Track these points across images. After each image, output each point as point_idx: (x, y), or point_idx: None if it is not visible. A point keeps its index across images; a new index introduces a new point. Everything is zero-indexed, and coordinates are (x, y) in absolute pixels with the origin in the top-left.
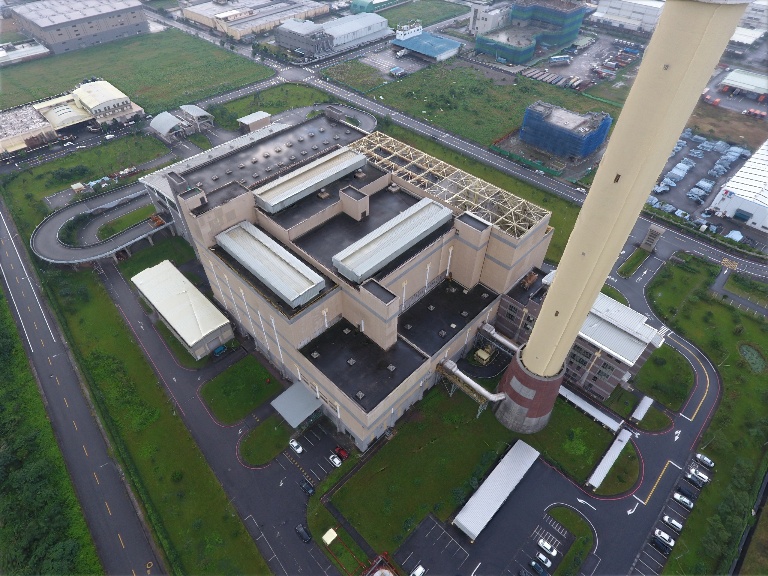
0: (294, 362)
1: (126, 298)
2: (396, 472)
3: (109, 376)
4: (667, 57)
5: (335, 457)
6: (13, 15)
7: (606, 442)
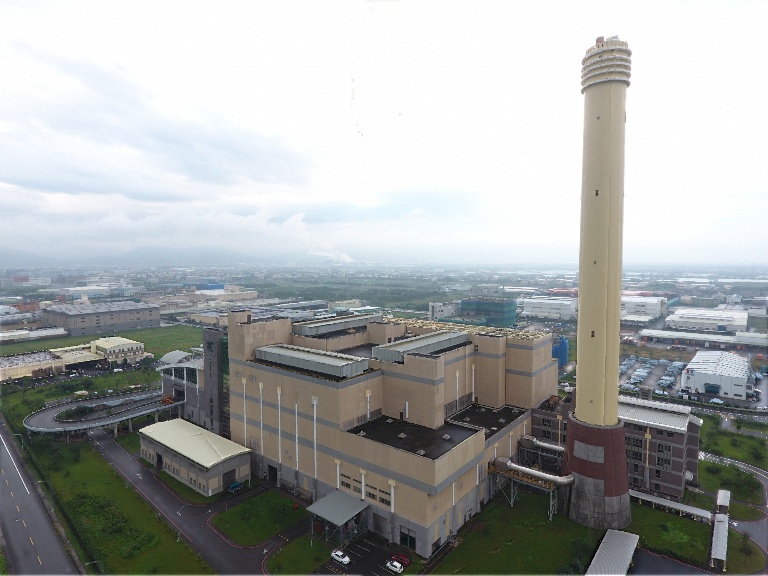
0: (334, 458)
1: (123, 459)
2: (476, 572)
3: (95, 513)
4: (597, 113)
5: (394, 561)
6: (42, 314)
7: (706, 531)
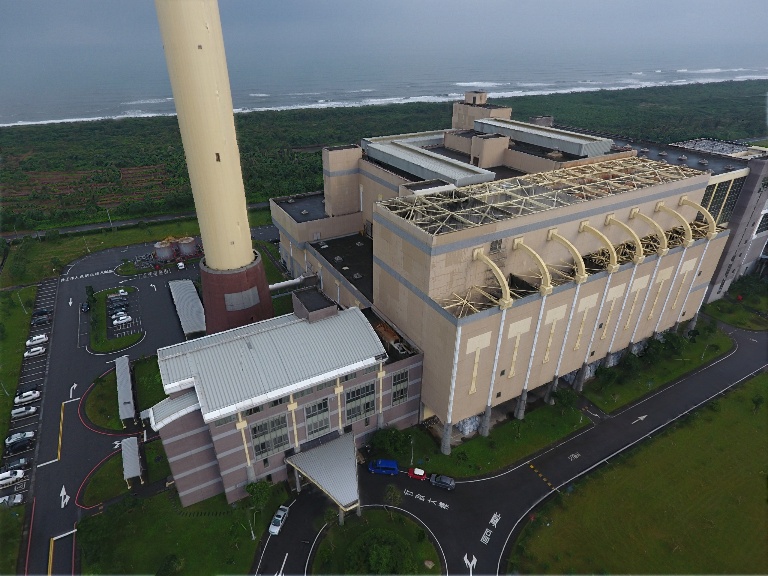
0: None
1: None
2: None
3: None
4: None
5: None
6: None
7: (144, 404)
